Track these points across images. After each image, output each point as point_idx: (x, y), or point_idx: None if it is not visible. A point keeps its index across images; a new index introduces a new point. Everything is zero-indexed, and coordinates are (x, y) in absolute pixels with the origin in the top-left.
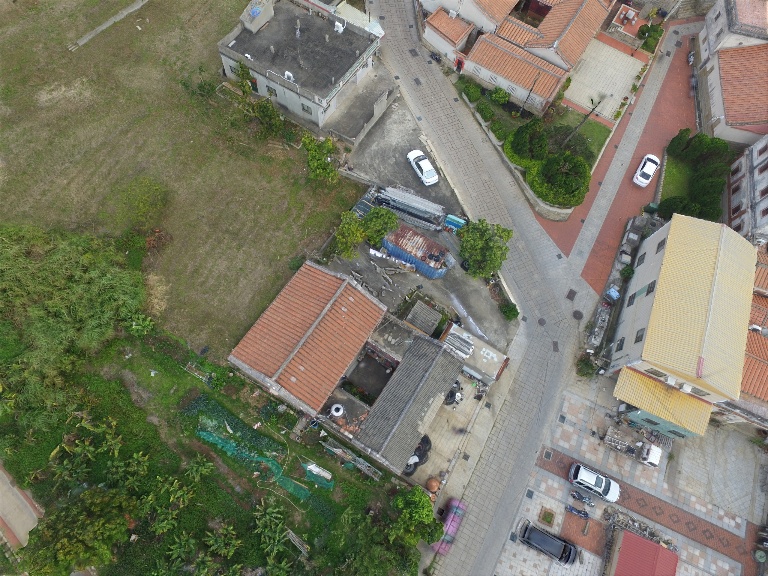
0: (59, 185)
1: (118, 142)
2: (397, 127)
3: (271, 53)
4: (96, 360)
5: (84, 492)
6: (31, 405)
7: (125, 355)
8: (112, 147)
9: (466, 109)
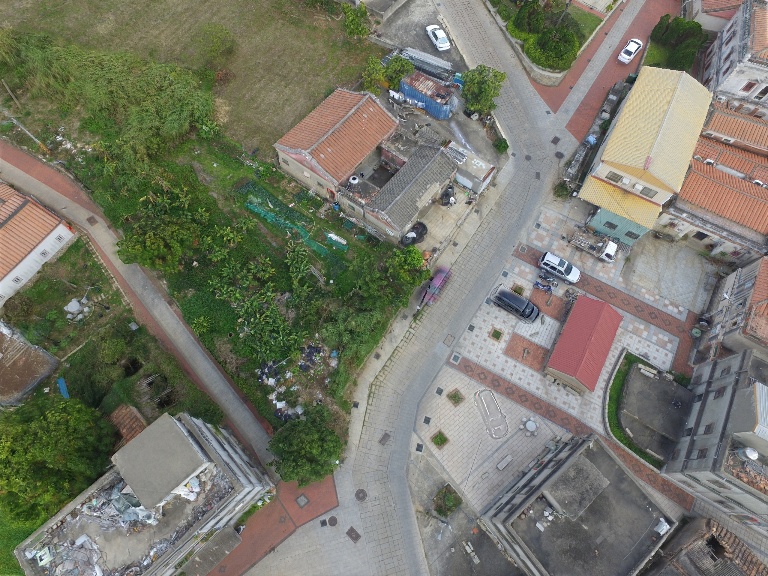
0: (152, 34)
1: (198, 8)
2: (419, 9)
3: None
4: (173, 152)
5: None
6: (126, 171)
7: (195, 151)
8: (193, 12)
9: None
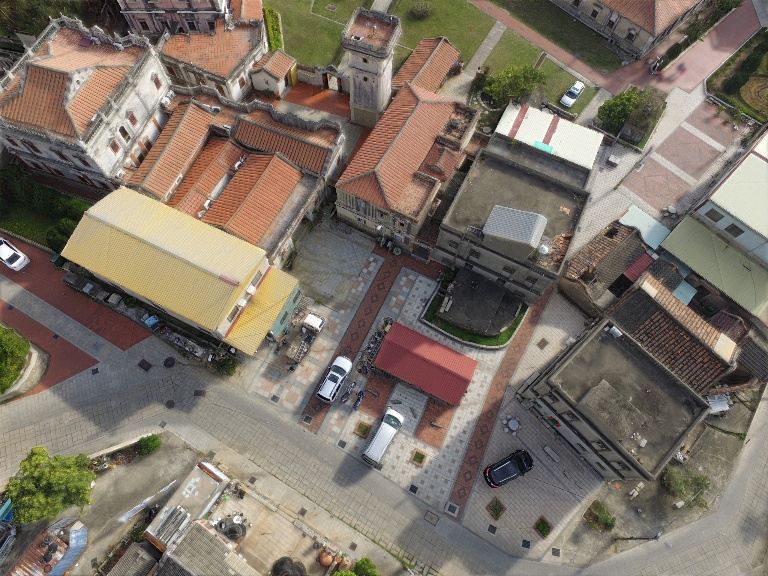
0: None
1: None
2: None
3: None
4: None
5: None
6: None
7: None
8: None
9: None
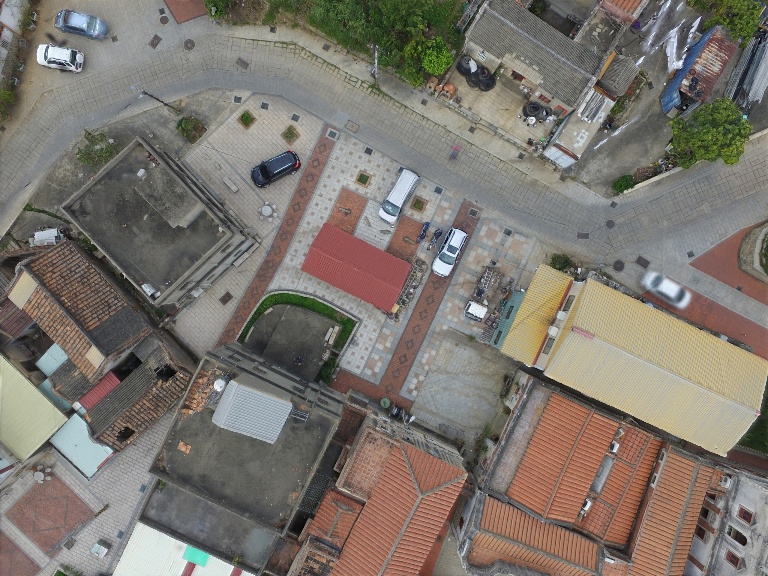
0: None
1: None
2: None
3: None
4: None
5: None
6: None
7: None
8: None
9: None
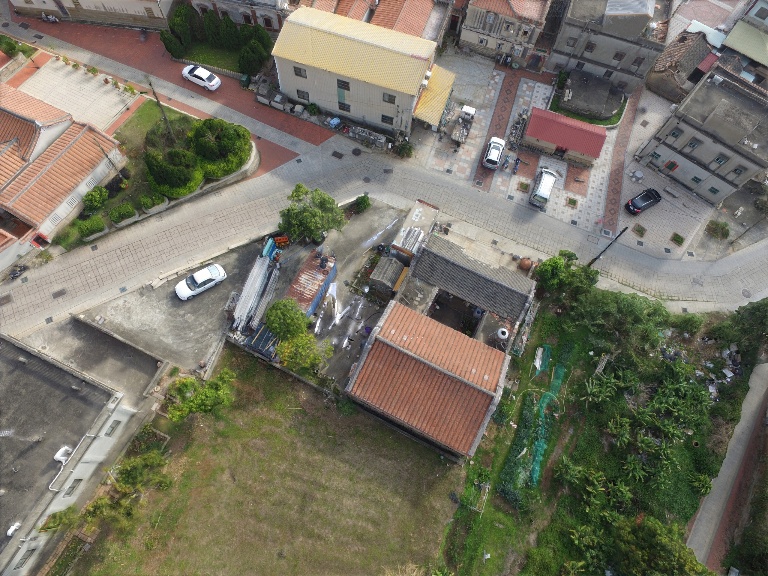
0: None
1: None
2: (136, 315)
3: (4, 495)
4: None
5: (635, 574)
6: None
7: None
8: None
9: (110, 237)
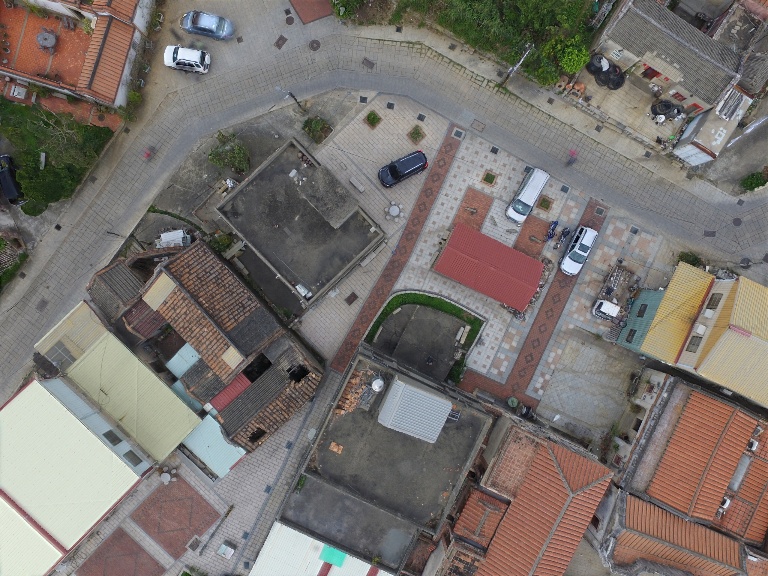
0: None
1: None
2: None
3: None
4: None
5: None
6: None
7: None
8: None
9: None
